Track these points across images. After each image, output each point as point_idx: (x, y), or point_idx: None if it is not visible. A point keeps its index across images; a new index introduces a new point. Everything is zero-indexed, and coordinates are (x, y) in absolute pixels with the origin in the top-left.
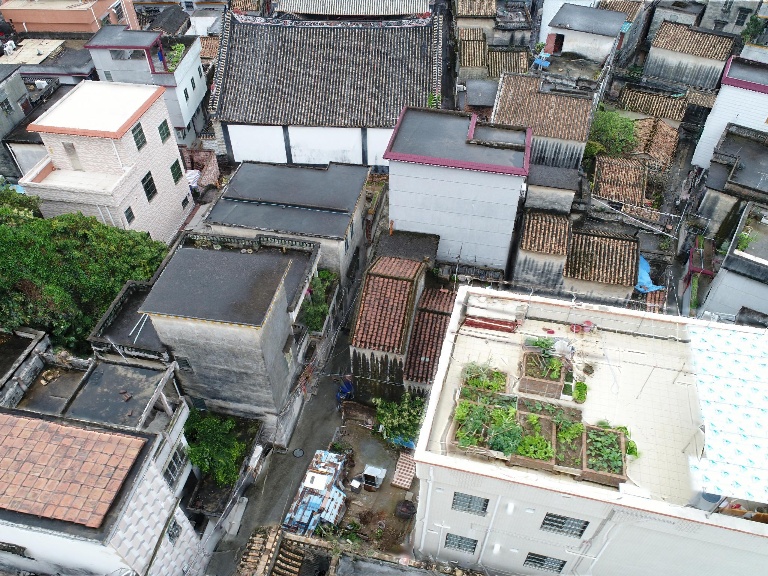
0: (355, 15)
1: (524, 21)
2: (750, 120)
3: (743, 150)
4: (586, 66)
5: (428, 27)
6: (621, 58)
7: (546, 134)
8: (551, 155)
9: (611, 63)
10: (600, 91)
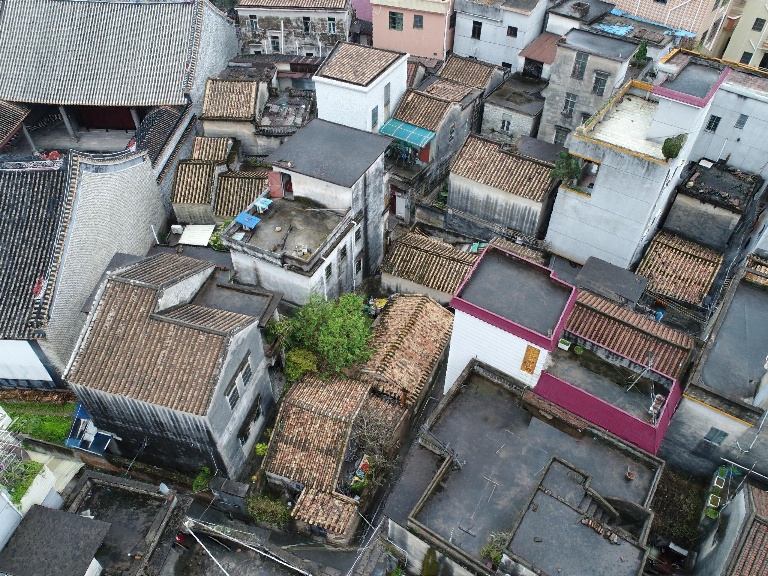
0: (87, 105)
1: (294, 125)
2: (500, 361)
3: (481, 417)
4: (321, 221)
5: (62, 172)
6: (430, 174)
7: (144, 398)
8: (169, 421)
9: (383, 201)
10: (352, 251)
